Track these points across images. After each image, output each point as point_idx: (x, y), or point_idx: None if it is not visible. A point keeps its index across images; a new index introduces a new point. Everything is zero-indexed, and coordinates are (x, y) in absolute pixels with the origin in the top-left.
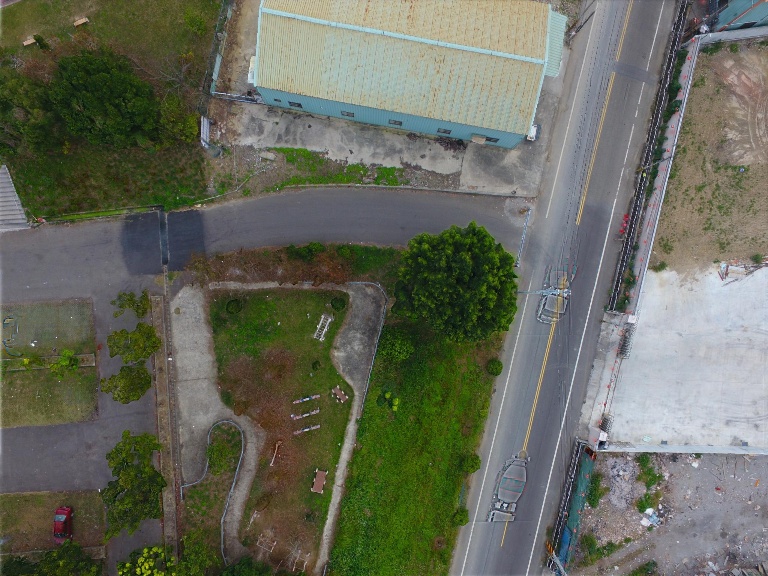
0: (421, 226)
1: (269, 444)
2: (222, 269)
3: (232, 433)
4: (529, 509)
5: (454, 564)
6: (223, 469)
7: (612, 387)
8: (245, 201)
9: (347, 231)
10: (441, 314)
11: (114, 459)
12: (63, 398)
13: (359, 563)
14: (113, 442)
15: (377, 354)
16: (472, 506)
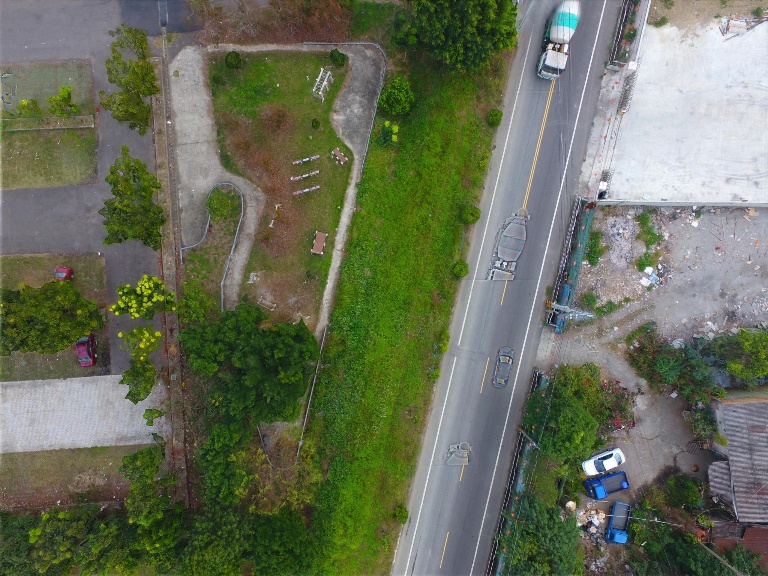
0: None
1: (269, 207)
2: (221, 31)
3: (232, 196)
4: (529, 268)
5: (454, 322)
6: (223, 233)
7: (612, 145)
8: None
9: None
10: (441, 21)
11: (113, 174)
12: (62, 160)
13: (359, 320)
14: None
15: (377, 116)
16: (472, 264)
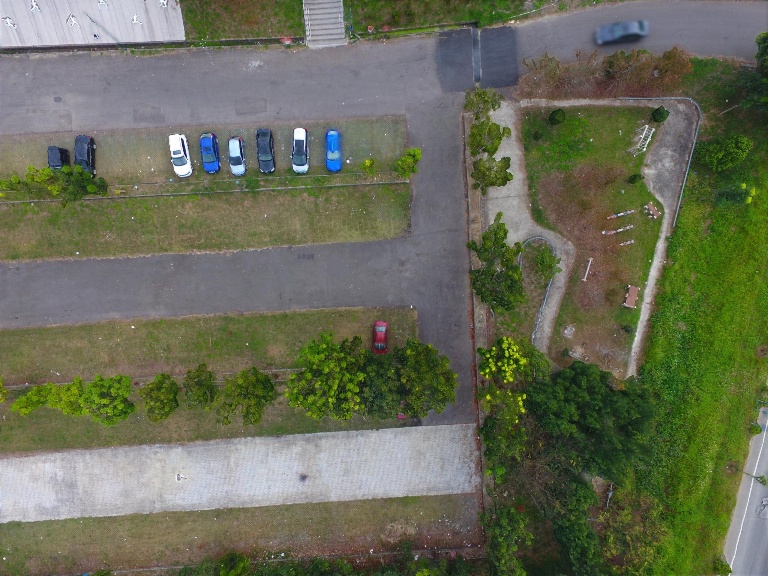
0: (745, 36)
1: (579, 261)
2: (534, 86)
3: (542, 250)
4: None
5: None
6: (533, 286)
7: None
8: (559, 16)
9: (667, 43)
10: None
11: (489, 240)
12: (377, 215)
13: (676, 375)
14: (425, 259)
15: (690, 170)
16: None
